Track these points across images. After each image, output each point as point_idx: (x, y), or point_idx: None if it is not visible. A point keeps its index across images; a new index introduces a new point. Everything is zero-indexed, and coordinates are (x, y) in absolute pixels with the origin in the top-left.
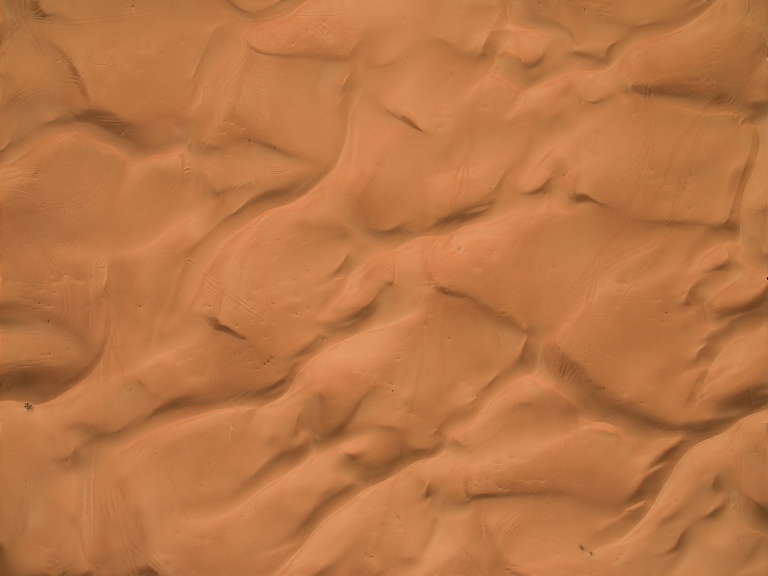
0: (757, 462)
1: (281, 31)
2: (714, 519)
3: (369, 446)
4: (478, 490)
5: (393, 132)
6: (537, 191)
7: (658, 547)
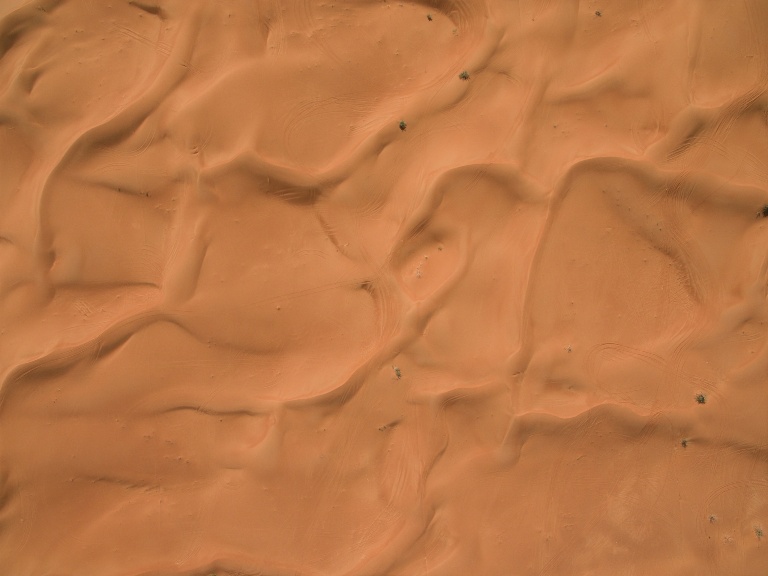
0: None
1: (130, 306)
2: None
3: None
4: None
5: (3, 222)
6: None
7: None
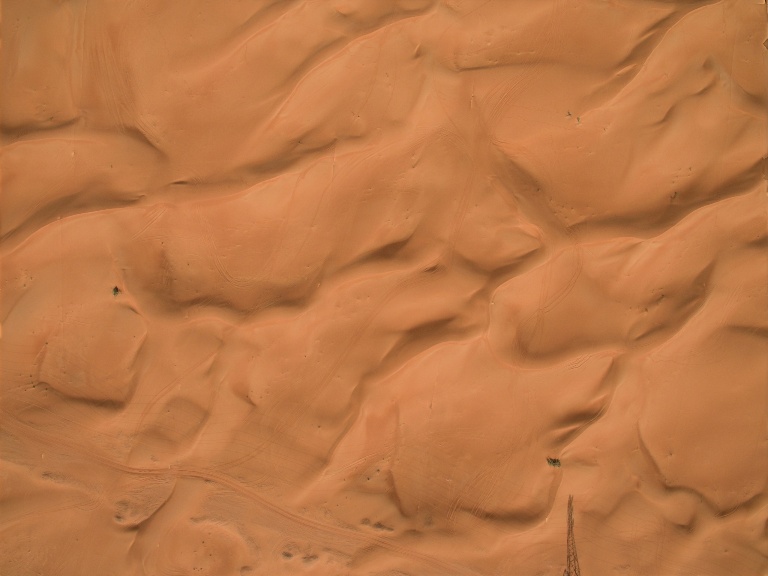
0: (749, 49)
1: None
2: (703, 96)
3: (361, 4)
4: (468, 64)
5: None
6: None
7: (646, 118)
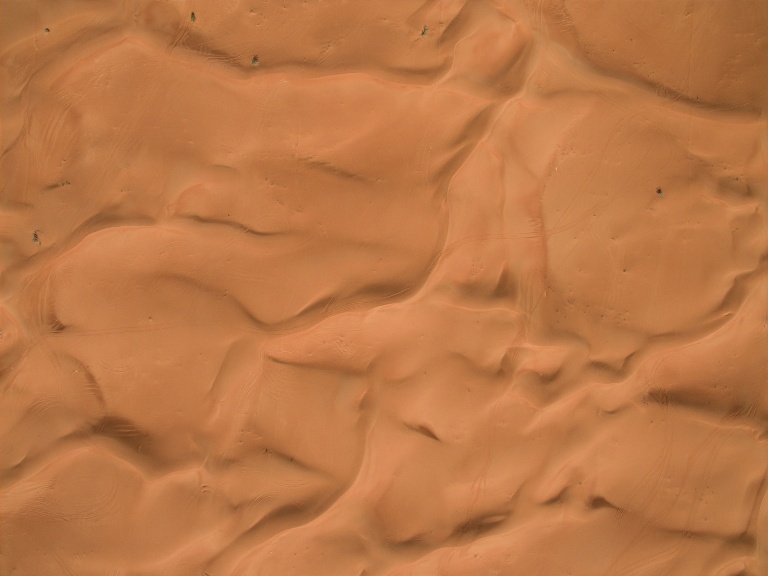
0: None
1: (298, 343)
2: None
3: None
4: None
5: (410, 445)
6: (554, 500)
7: None
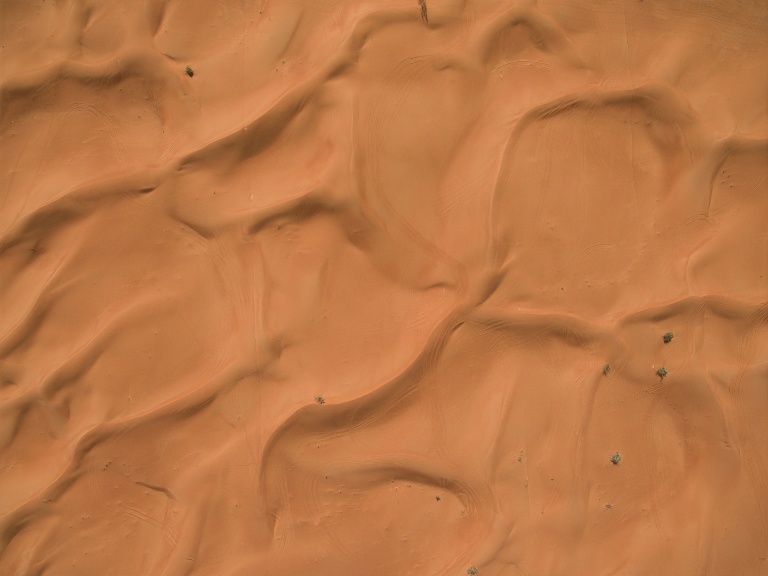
0: None
1: None
2: None
3: None
4: None
5: None
6: None
7: None
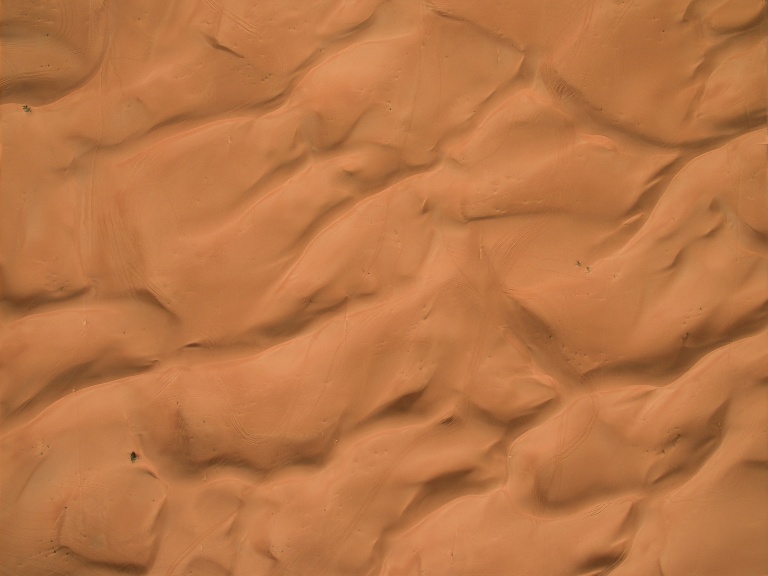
0: (754, 187)
1: None
2: (711, 238)
3: (367, 162)
4: (475, 213)
5: None
6: None
7: (655, 264)
